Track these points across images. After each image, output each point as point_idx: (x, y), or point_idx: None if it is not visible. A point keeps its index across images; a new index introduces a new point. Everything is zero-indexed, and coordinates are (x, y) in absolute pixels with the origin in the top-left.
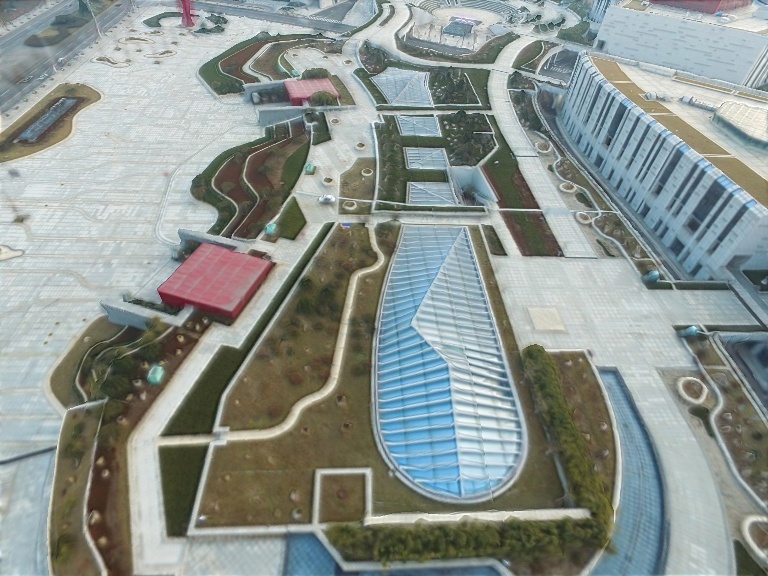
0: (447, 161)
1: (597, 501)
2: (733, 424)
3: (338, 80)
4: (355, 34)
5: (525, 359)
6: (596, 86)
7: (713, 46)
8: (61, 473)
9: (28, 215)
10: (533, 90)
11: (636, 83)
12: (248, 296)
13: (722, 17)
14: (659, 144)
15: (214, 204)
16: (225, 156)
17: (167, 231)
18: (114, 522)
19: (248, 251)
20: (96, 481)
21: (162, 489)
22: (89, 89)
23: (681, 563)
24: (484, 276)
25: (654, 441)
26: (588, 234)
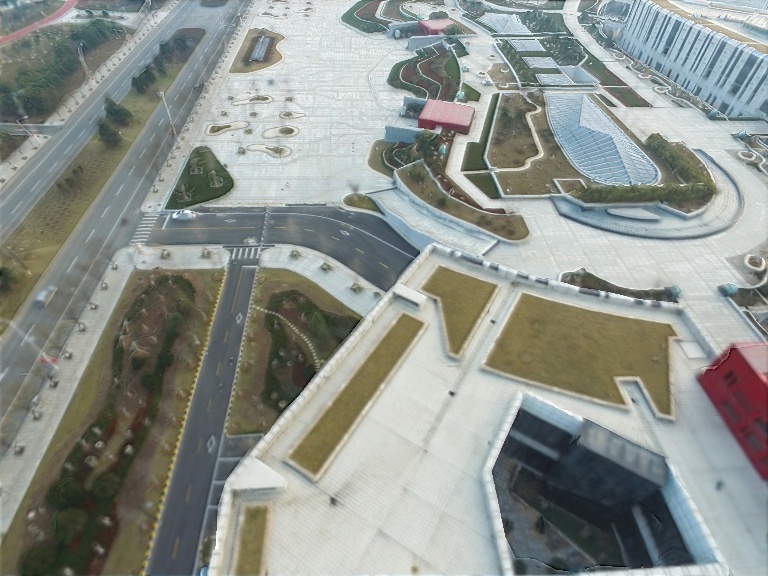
0: (556, 64)
1: (707, 180)
2: None
3: (454, 20)
4: None
5: (647, 144)
6: (654, 13)
7: None
8: (414, 188)
9: (293, 97)
10: (599, 25)
11: (683, 10)
12: None
13: None
14: (708, 41)
15: (409, 90)
16: (399, 66)
17: (387, 104)
18: (462, 194)
19: None
20: (442, 183)
21: (476, 186)
22: (272, 32)
23: (752, 207)
24: (607, 114)
25: (729, 173)
26: (665, 98)
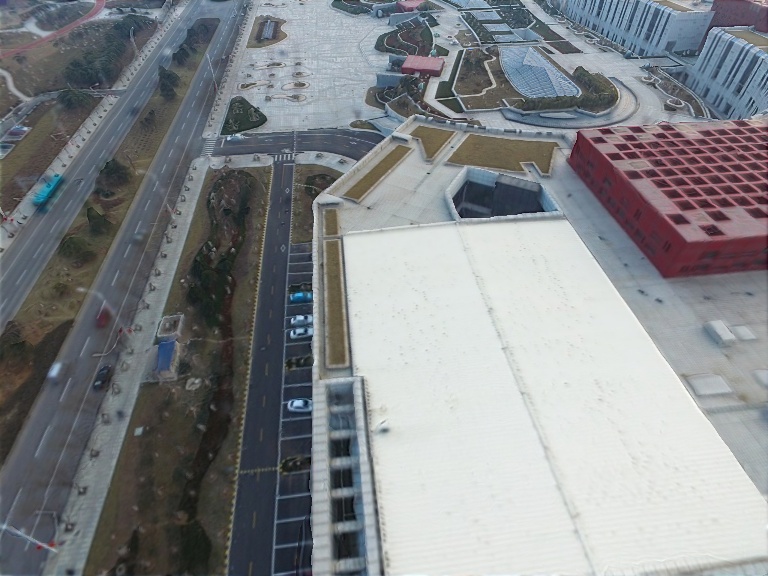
0: None
1: (612, 91)
2: None
3: (427, 0)
4: None
5: None
6: None
7: None
8: (401, 112)
9: (301, 62)
10: None
11: None
12: (441, 69)
13: None
14: (627, 2)
15: (393, 53)
16: (383, 36)
17: (376, 63)
18: (436, 111)
19: None
20: None
21: None
22: None
23: (644, 108)
24: (547, 59)
25: (633, 90)
26: (594, 47)
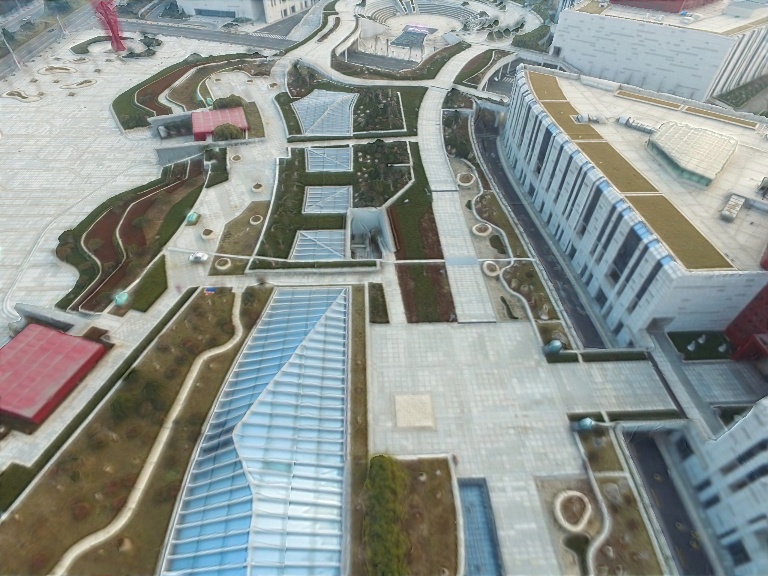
0: (351, 202)
1: None
2: (613, 563)
3: (255, 108)
4: (289, 52)
5: None
6: (526, 107)
7: (674, 50)
8: None
9: None
10: (470, 109)
11: (572, 102)
12: (62, 393)
13: (685, 17)
14: (581, 178)
15: (77, 265)
16: (108, 204)
17: (16, 301)
18: None
19: (87, 329)
20: None
21: None
22: None
23: None
24: (353, 354)
25: None
26: (493, 289)
